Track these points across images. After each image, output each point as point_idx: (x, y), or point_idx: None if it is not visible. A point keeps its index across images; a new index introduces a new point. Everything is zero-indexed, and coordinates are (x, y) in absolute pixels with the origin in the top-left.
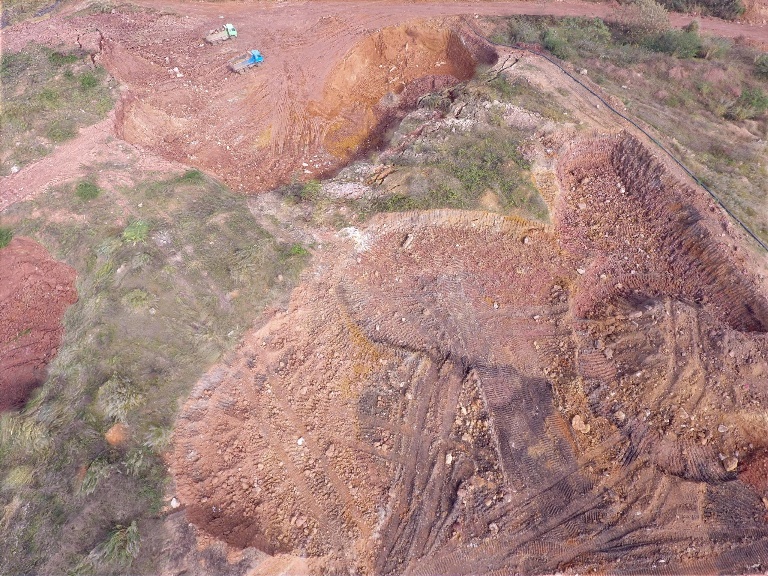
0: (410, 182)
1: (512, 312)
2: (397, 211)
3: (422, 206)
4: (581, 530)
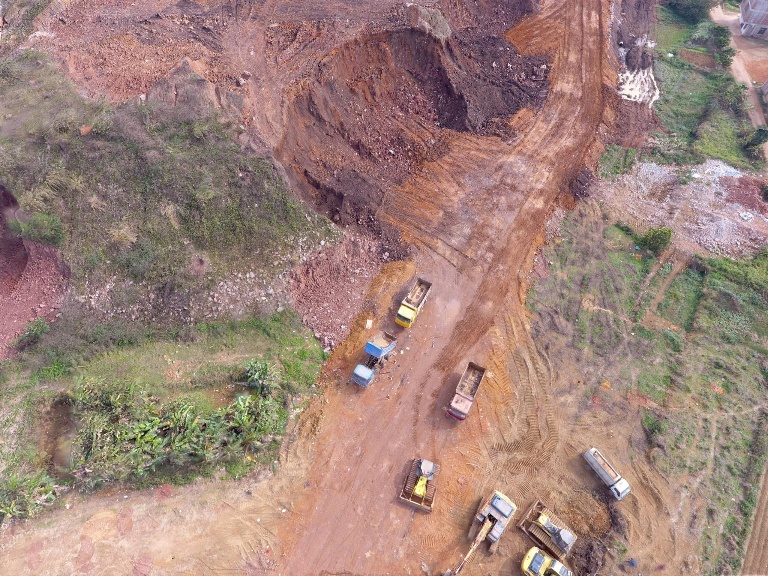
0: (22, 6)
1: (141, 2)
2: (39, 13)
3: (46, 2)
4: (241, 7)
